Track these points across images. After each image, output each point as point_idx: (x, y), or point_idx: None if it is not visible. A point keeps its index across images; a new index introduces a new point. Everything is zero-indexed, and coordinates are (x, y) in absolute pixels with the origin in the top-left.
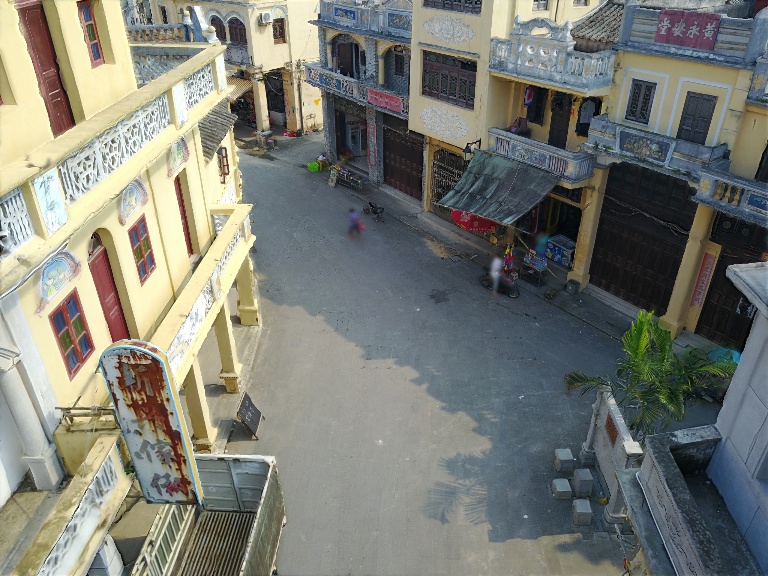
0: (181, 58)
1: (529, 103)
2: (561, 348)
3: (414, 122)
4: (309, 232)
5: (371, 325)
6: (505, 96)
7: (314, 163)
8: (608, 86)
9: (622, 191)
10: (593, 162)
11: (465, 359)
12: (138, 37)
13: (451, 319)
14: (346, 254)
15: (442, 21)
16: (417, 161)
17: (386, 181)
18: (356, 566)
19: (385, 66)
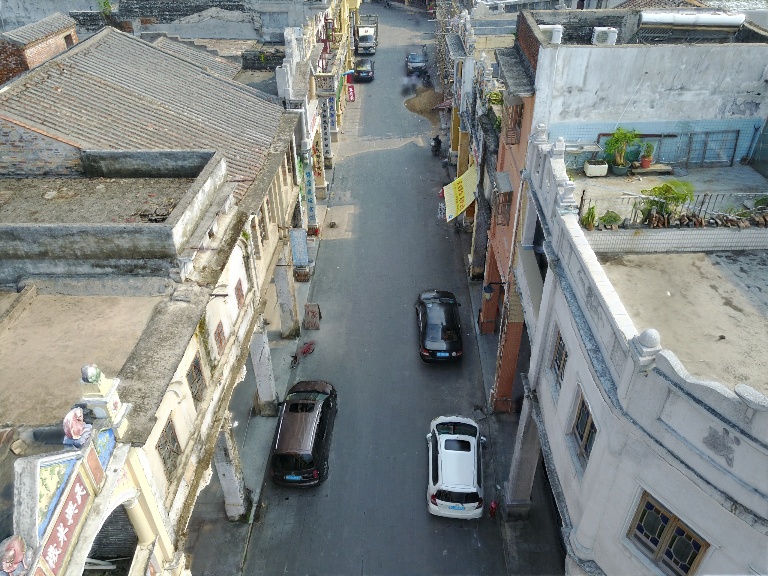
0: None
1: None
2: None
3: None
4: None
5: None
6: None
7: None
8: None
9: None
10: None
11: (417, 26)
12: None
13: (414, 22)
14: None
15: None
16: None
17: None
18: (393, 42)
19: None
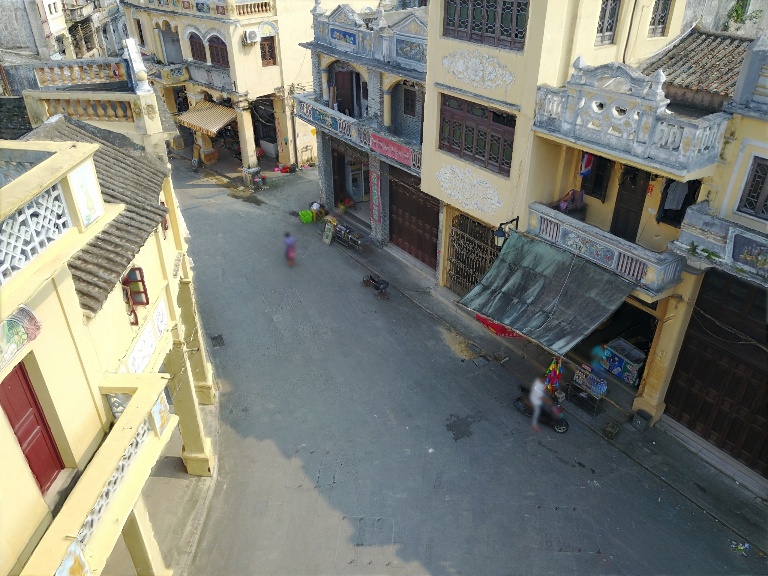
0: (20, 164)
1: (587, 172)
2: (634, 531)
3: (428, 183)
4: (293, 314)
5: (366, 478)
6: (553, 160)
7: (307, 211)
8: (713, 163)
9: (723, 306)
10: (682, 264)
11: (497, 549)
12: (63, 75)
13: (476, 470)
14: (338, 351)
15: (468, 57)
16: (431, 222)
17: (392, 240)
18: None
19: (392, 102)
